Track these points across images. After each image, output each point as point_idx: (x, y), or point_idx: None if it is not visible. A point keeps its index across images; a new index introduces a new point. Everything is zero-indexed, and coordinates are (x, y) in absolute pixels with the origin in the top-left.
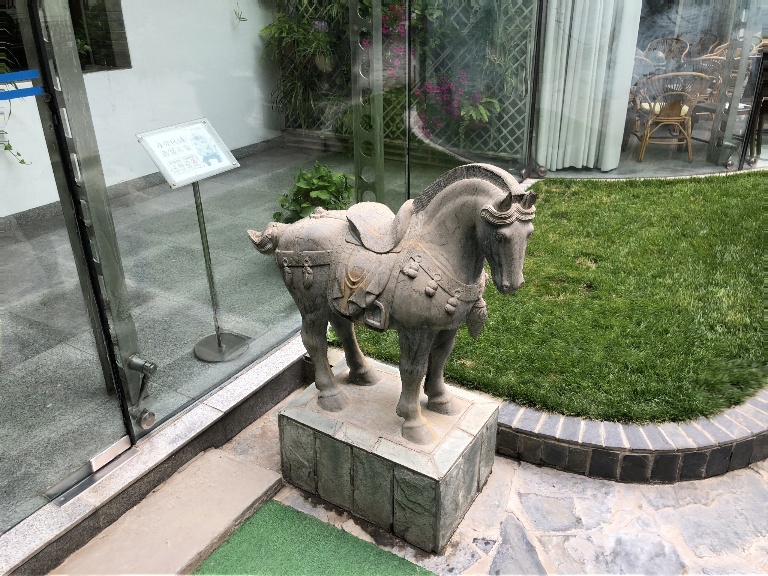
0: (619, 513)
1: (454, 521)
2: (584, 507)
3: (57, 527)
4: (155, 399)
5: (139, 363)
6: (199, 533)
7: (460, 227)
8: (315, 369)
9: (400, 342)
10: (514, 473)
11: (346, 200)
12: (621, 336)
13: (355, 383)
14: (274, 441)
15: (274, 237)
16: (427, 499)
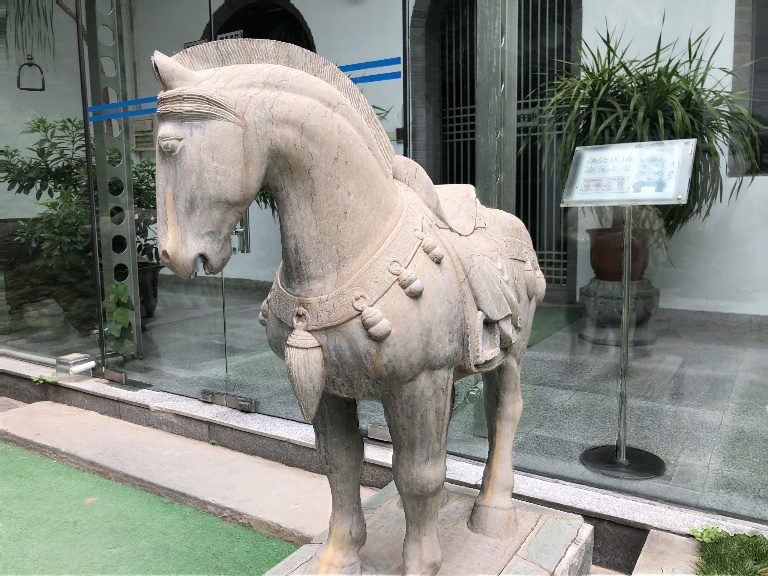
0: None
1: None
2: None
3: (302, 437)
4: None
5: None
6: (304, 519)
7: None
8: None
9: None
10: None
11: None
12: None
13: None
14: None
15: None
16: None
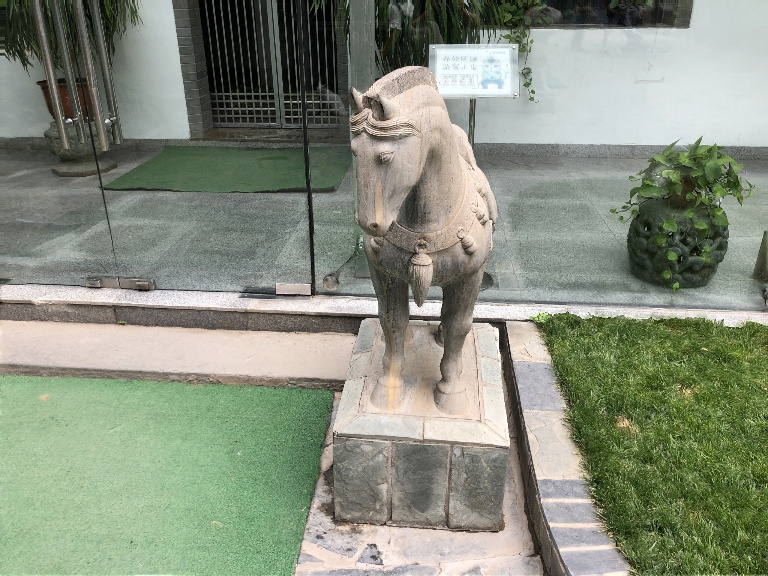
0: None
1: (372, 510)
2: None
3: (220, 304)
4: None
5: (359, 241)
6: (265, 367)
7: None
8: None
9: None
10: (512, 555)
11: (716, 197)
12: None
13: None
14: None
15: None
16: None
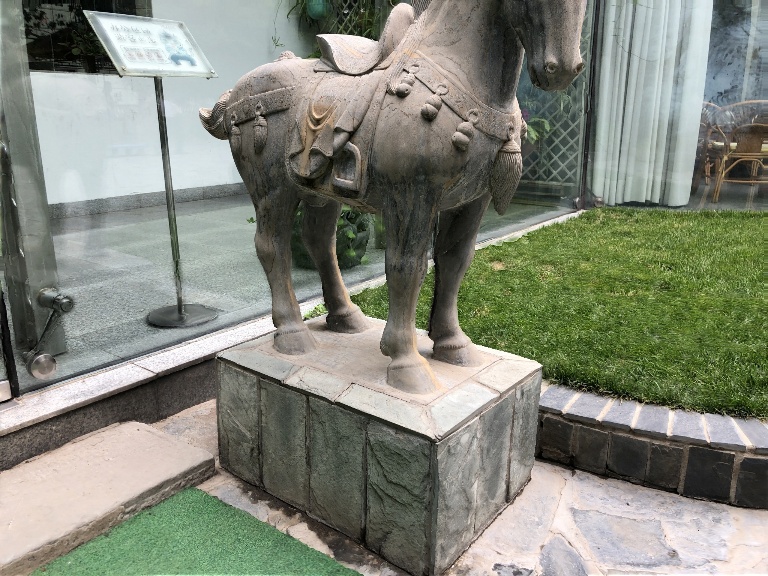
0: (739, 548)
1: (464, 531)
2: (679, 535)
3: None
4: (73, 356)
5: (50, 296)
6: (62, 515)
7: (479, 4)
8: None
9: (385, 216)
10: (565, 484)
11: None
12: (718, 329)
13: (333, 330)
14: None
15: None
16: (416, 476)
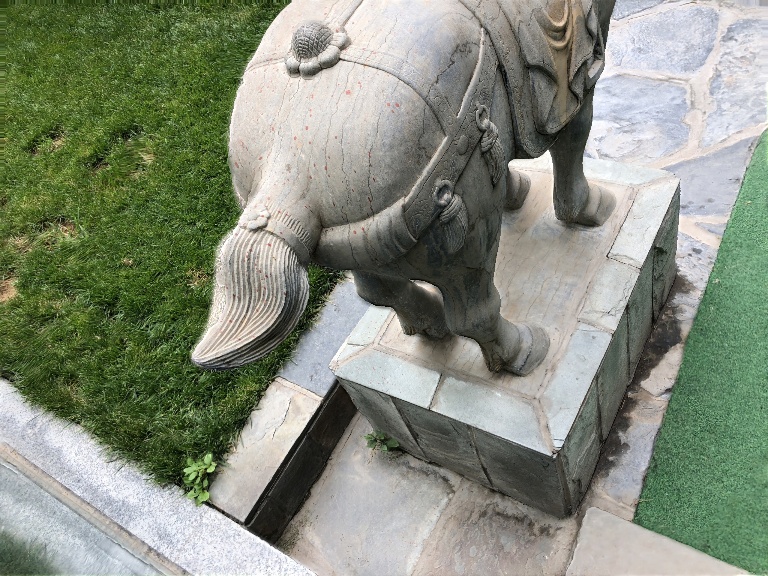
0: None
1: None
2: None
3: None
4: None
5: None
6: None
7: None
8: (499, 342)
9: None
10: None
11: None
12: None
13: None
14: (464, 567)
15: (298, 241)
16: None
